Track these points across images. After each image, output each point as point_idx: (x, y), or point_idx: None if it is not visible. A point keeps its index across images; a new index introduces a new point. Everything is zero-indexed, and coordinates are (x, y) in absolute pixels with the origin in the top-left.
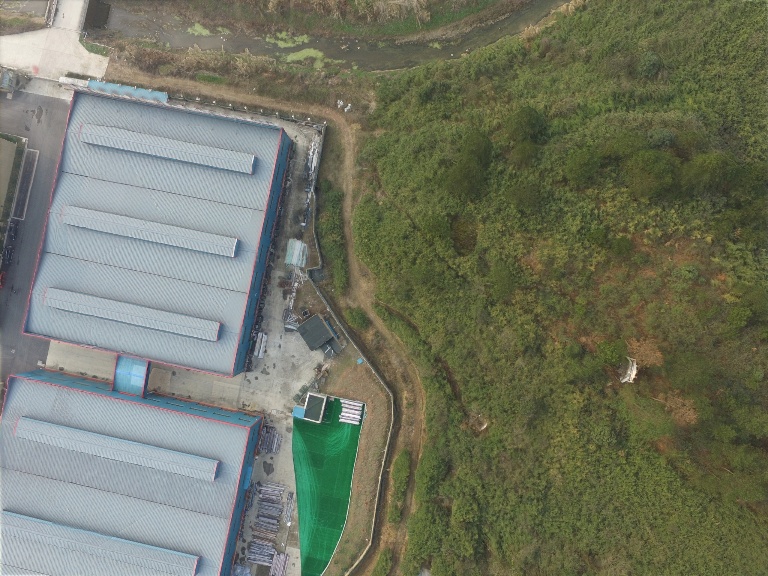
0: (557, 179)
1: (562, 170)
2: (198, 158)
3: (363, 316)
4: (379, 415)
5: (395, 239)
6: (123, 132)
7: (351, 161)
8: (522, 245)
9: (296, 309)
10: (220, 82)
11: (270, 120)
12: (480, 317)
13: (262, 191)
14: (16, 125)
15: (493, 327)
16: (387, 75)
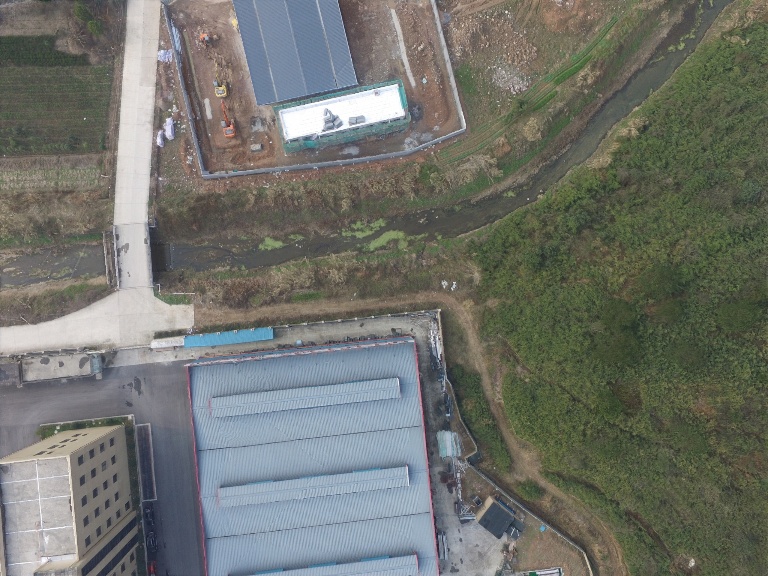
0: (711, 330)
1: (714, 321)
2: (343, 398)
3: (537, 488)
4: (578, 575)
5: (559, 416)
6: (256, 395)
7: (475, 339)
8: (691, 396)
9: (466, 499)
10: (318, 297)
11: (381, 321)
12: (669, 471)
13: (413, 407)
14: (116, 404)
15: (684, 478)
16: (474, 238)
